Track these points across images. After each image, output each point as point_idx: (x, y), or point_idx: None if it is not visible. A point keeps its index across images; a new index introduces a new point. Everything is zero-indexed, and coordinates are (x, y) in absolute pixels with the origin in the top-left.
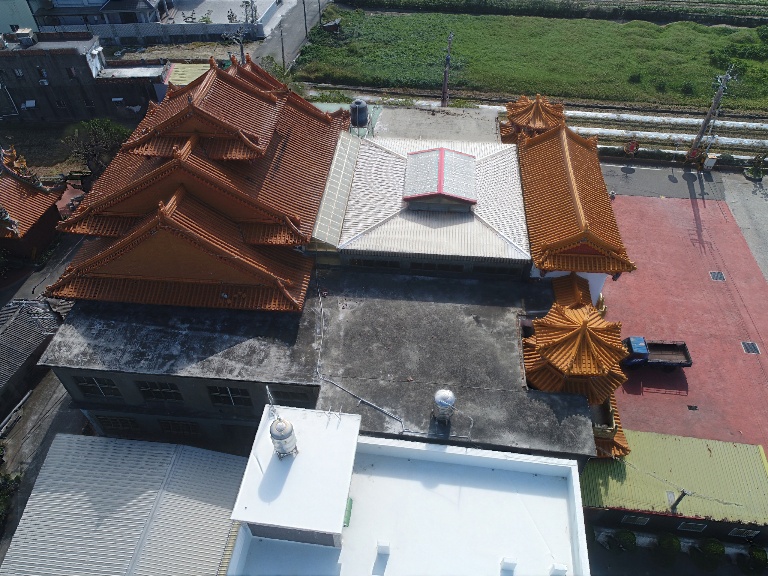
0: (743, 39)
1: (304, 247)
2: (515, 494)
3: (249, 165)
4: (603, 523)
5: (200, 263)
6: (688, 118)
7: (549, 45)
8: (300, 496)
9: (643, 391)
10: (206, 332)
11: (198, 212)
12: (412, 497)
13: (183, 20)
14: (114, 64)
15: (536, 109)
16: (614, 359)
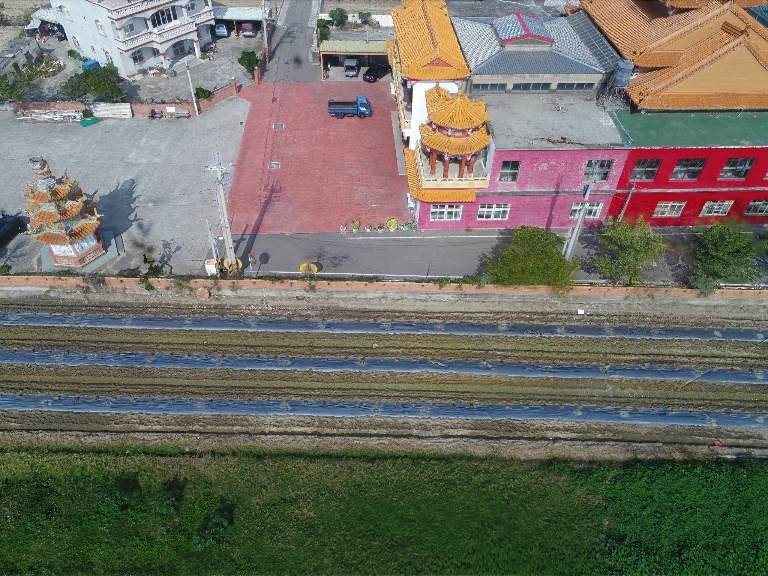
0: None
1: None
2: None
3: None
4: None
5: None
6: (163, 413)
7: None
8: None
9: None
10: None
11: None
12: None
13: None
14: None
15: None
16: None
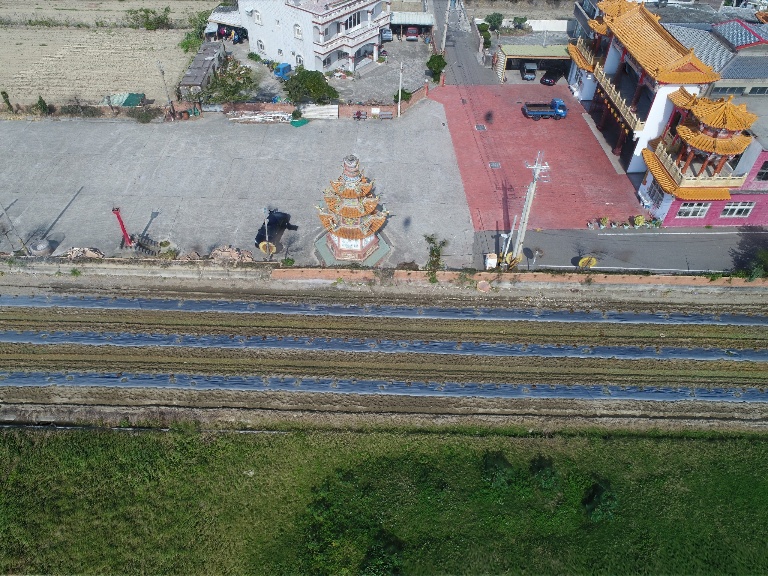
0: None
1: None
2: None
3: None
4: None
5: None
6: (495, 397)
7: None
8: None
9: None
10: None
11: None
12: None
13: None
14: None
15: None
16: None
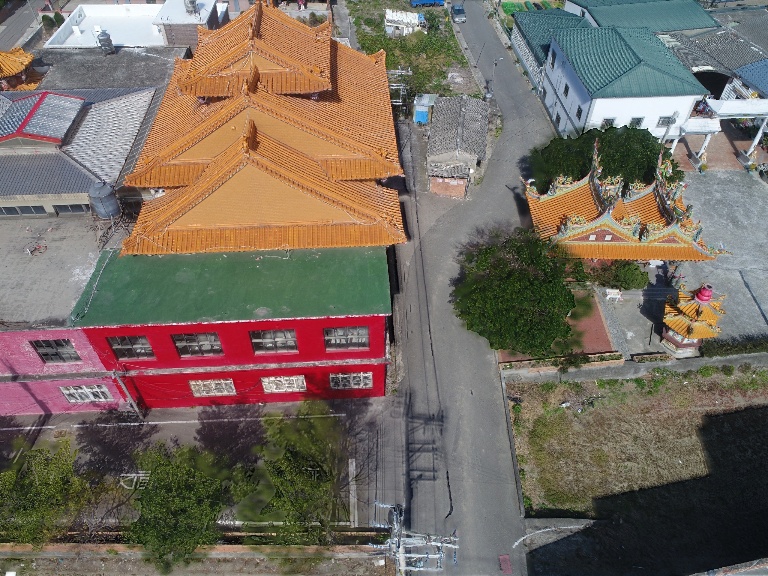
0: None
1: None
2: None
3: None
4: None
5: None
6: None
7: None
8: None
9: None
10: None
11: None
12: None
13: None
14: None
15: None
16: None
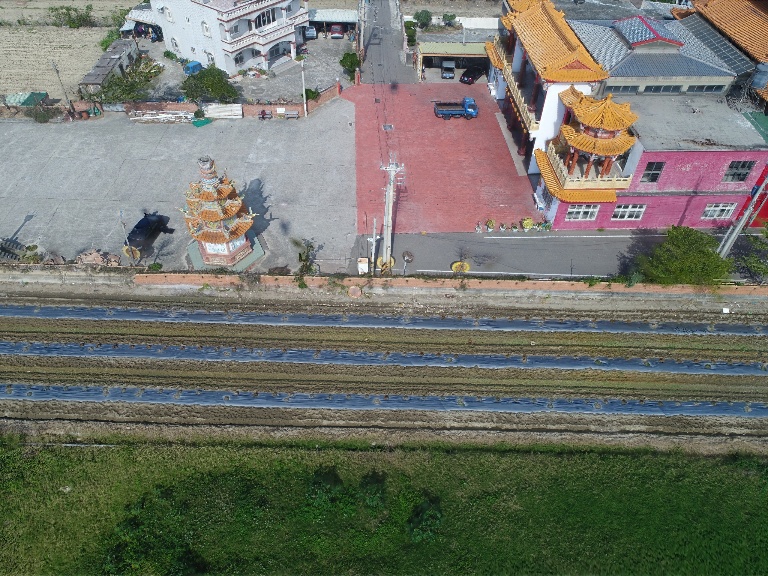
0: None
1: None
2: None
3: None
4: None
5: None
6: (343, 409)
7: None
8: None
9: None
10: None
11: None
12: None
13: None
14: None
15: None
16: None
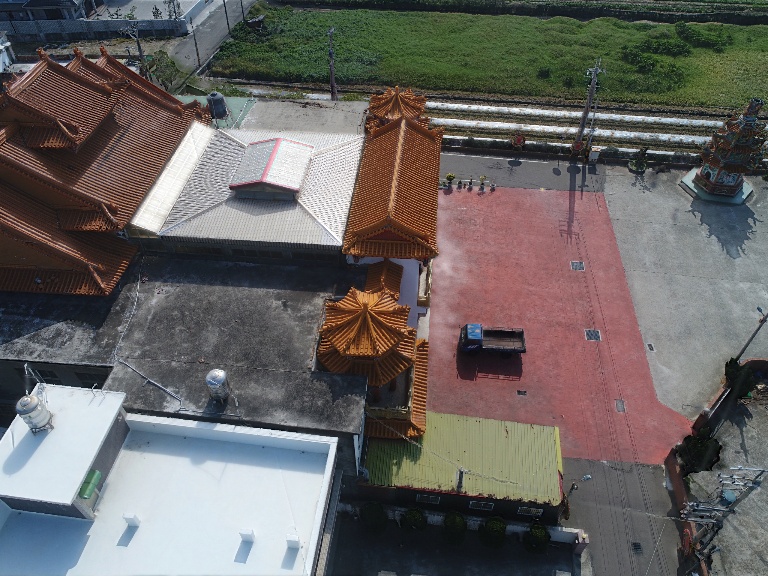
0: (659, 35)
1: (127, 234)
2: (277, 470)
3: (74, 154)
4: (398, 502)
5: (10, 248)
6: None
7: (467, 41)
8: (42, 469)
9: (477, 377)
10: (19, 316)
11: (10, 199)
12: (177, 473)
13: (109, 16)
14: (24, 59)
15: (395, 101)
16: (393, 341)
